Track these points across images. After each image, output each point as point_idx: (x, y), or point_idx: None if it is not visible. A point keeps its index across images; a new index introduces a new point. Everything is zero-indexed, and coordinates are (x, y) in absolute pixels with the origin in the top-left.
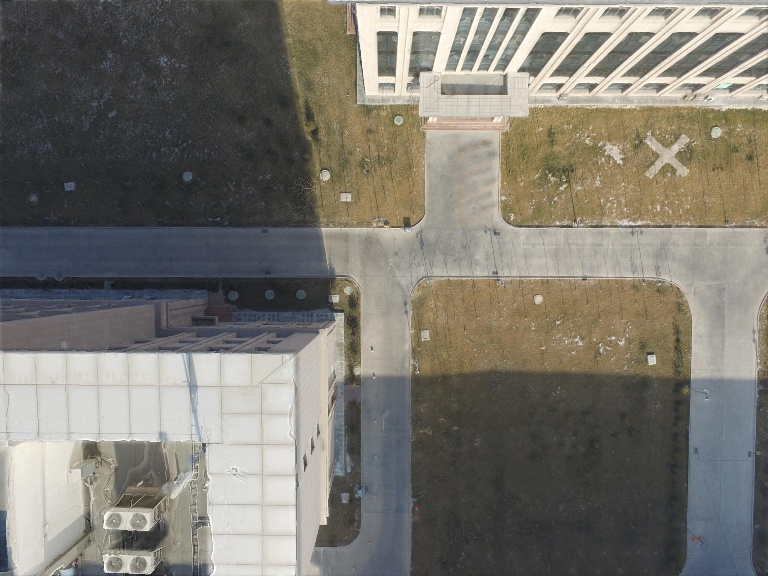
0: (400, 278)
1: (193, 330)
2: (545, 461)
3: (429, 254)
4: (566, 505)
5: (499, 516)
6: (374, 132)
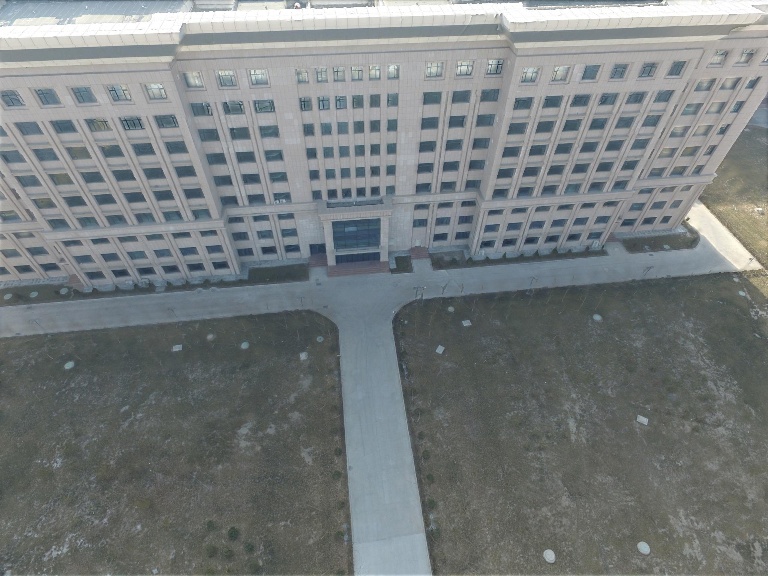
0: None
1: (24, 222)
2: None
3: None
4: None
5: None
6: None
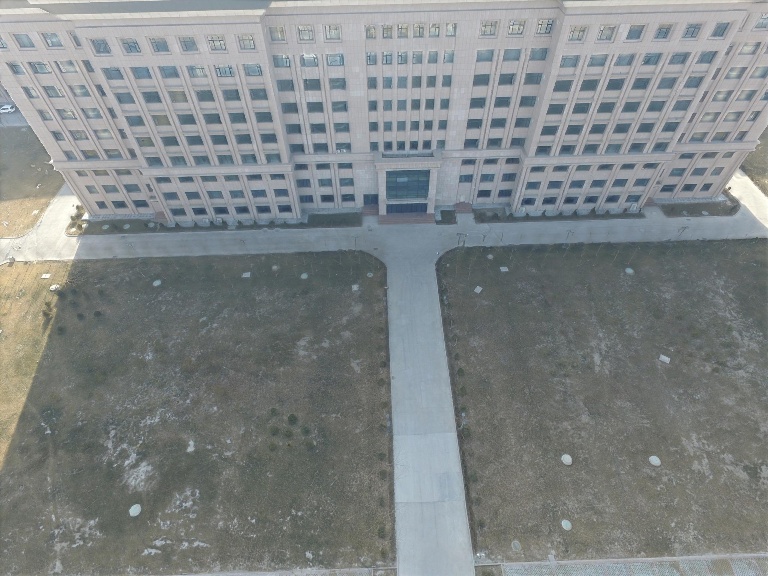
0: (34, 237)
1: (125, 160)
2: (0, 168)
3: (6, 249)
4: (1, 154)
5: (42, 149)
6: (1, 314)
